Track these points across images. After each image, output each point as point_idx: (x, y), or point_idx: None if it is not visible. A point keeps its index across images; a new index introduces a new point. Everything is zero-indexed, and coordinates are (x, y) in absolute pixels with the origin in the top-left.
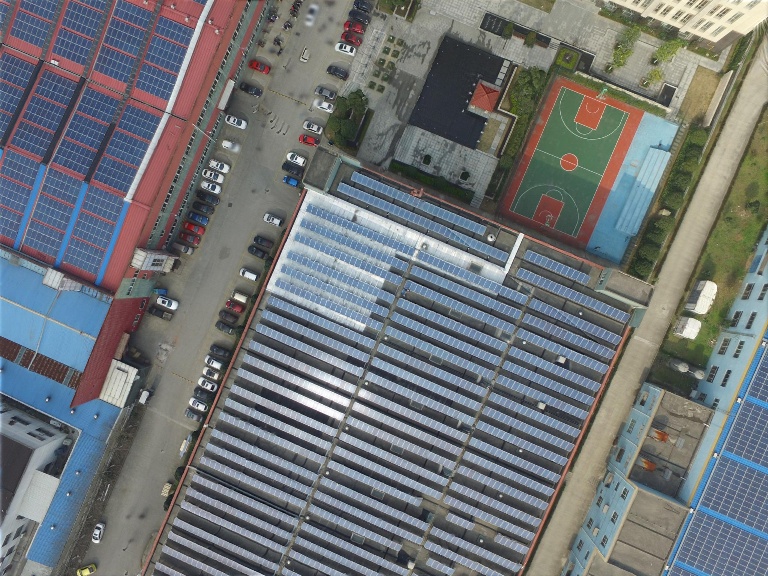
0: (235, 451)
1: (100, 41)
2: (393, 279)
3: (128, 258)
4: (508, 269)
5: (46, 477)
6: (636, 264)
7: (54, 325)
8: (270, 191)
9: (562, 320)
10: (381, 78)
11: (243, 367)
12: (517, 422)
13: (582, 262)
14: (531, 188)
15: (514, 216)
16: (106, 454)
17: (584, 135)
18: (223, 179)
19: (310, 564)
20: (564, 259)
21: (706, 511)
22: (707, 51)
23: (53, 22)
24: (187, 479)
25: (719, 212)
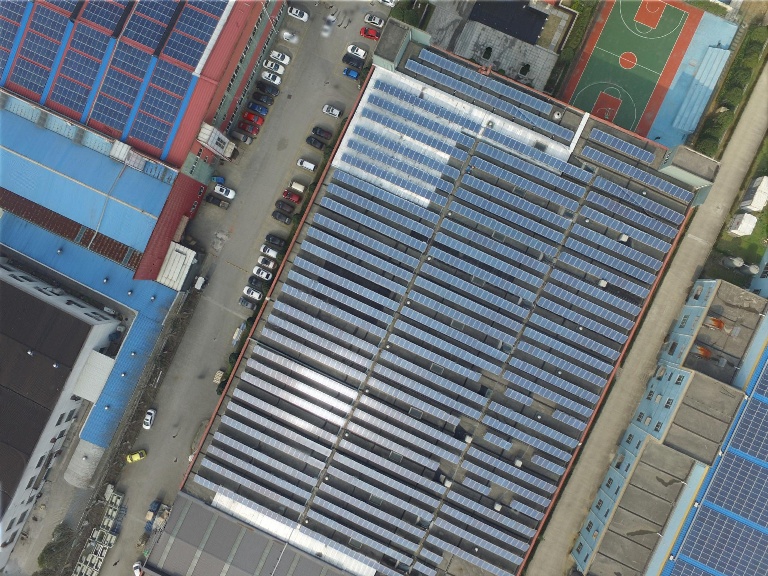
0: (296, 324)
1: None
2: (459, 155)
3: (194, 133)
4: (573, 148)
5: (102, 357)
6: None
7: (115, 204)
8: (329, 83)
9: (626, 199)
10: None
11: (307, 240)
12: (578, 299)
13: (647, 143)
14: (589, 85)
15: None
16: (161, 338)
17: (643, 34)
18: (283, 70)
19: (368, 437)
20: (629, 140)
21: (760, 398)
22: None
23: None
24: (247, 351)
25: None
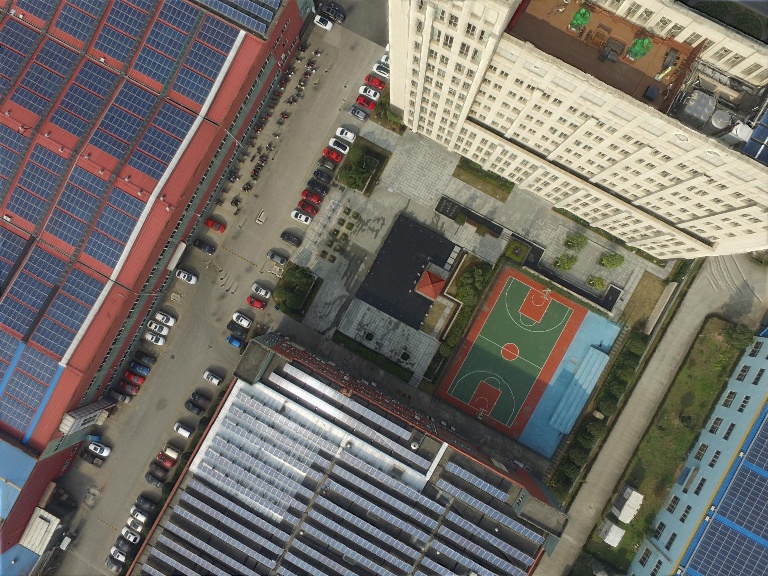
0: None
1: (53, 203)
2: (314, 475)
3: (57, 420)
4: (429, 477)
5: None
6: (565, 465)
7: None
8: (213, 348)
9: (477, 535)
10: (333, 248)
11: (157, 546)
12: None
13: (503, 478)
14: (470, 373)
15: (451, 399)
16: None
17: (527, 326)
18: (168, 331)
19: None
20: (486, 472)
21: None
22: (655, 258)
23: (9, 179)
24: None
25: (653, 418)
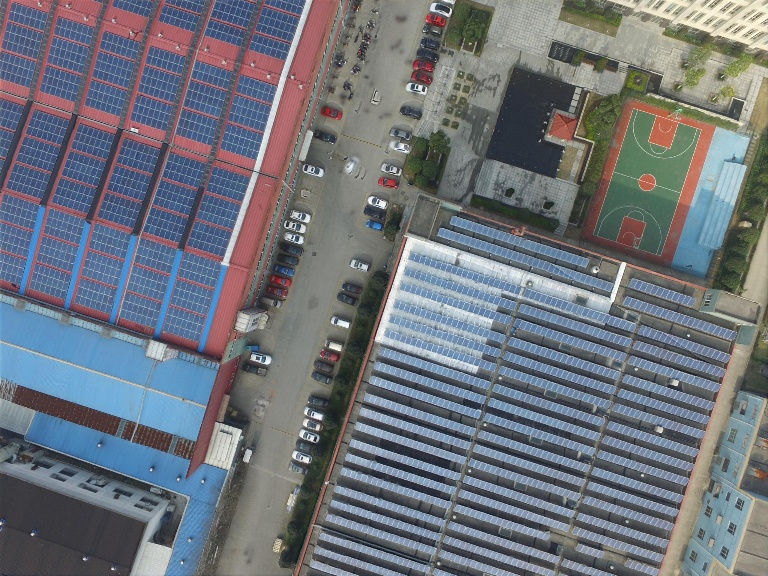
0: (359, 505)
1: (180, 105)
2: (502, 319)
3: (230, 322)
4: (614, 298)
5: (158, 548)
6: (724, 277)
7: (154, 394)
8: (353, 237)
9: (672, 344)
10: (454, 114)
11: (360, 421)
12: (637, 448)
13: (685, 285)
14: (612, 211)
15: (598, 240)
16: (215, 517)
17: (659, 154)
18: (305, 229)
19: None
20: (667, 283)
21: None
22: None
23: (129, 89)
24: (313, 538)
25: None
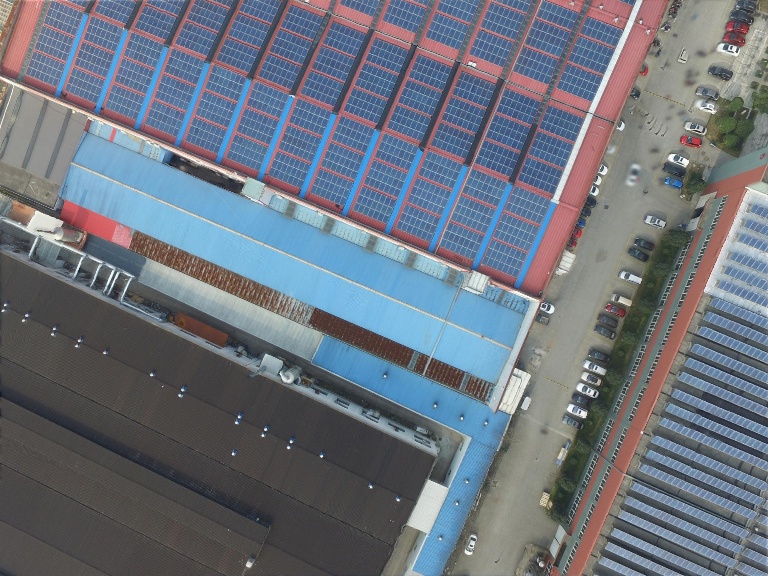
0: (676, 459)
1: (521, 42)
2: None
3: (552, 260)
4: None
5: (435, 486)
6: None
7: (452, 329)
8: (649, 193)
9: None
10: (764, 78)
11: None
12: None
13: None
14: None
15: None
16: None
17: None
18: (601, 181)
19: None
20: None
21: None
22: None
23: (472, 24)
24: (622, 488)
25: None
